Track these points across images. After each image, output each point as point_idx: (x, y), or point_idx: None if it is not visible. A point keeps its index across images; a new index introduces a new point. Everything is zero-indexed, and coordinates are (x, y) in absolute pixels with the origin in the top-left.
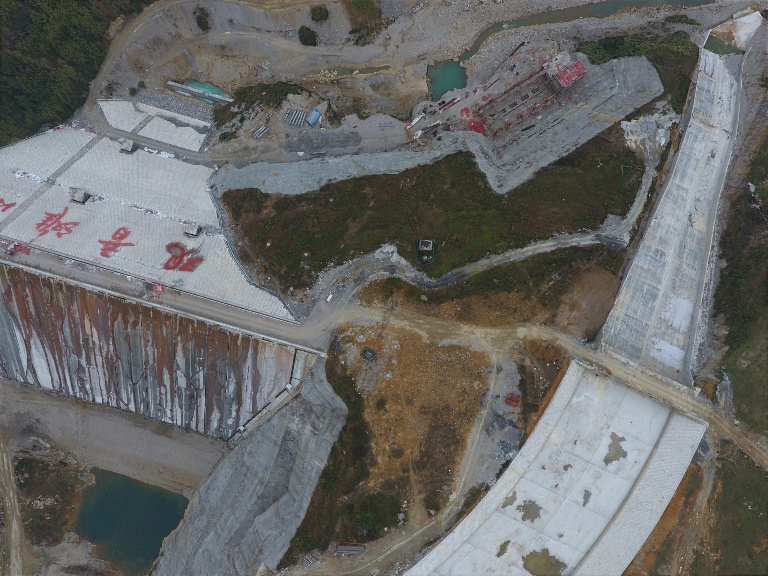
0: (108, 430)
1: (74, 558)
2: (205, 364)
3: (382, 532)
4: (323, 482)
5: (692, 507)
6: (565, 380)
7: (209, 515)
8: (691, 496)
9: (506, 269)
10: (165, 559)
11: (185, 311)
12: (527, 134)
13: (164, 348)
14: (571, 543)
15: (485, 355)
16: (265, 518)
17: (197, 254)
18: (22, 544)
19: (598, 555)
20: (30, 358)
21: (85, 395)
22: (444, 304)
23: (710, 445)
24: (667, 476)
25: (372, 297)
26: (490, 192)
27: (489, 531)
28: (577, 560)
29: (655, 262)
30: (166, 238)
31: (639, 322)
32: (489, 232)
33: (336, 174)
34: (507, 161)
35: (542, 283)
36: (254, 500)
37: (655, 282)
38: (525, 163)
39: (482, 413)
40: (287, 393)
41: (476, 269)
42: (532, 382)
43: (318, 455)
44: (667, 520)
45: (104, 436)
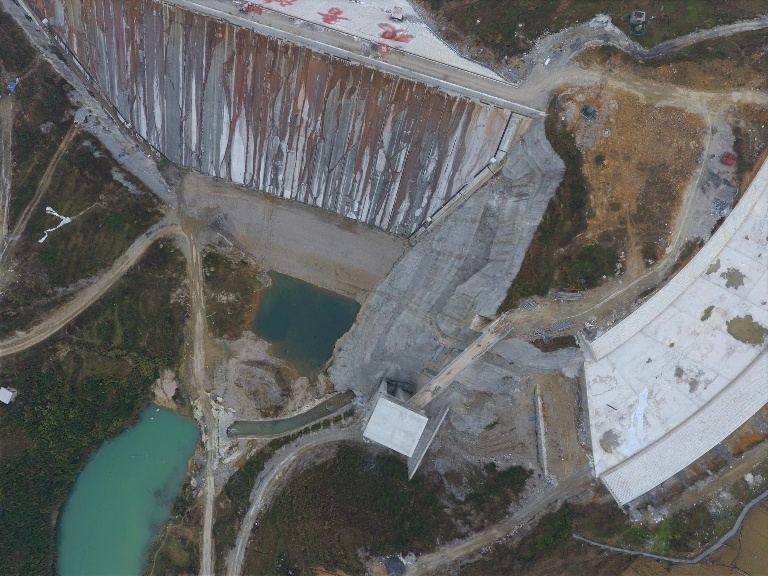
0: (293, 226)
1: (252, 354)
2: (411, 139)
3: (600, 281)
4: (540, 235)
5: None
6: None
7: (399, 298)
8: None
9: (716, 41)
10: (346, 351)
11: (409, 70)
12: None
13: (373, 121)
14: None
15: (700, 117)
16: (470, 283)
17: (407, 33)
18: (205, 336)
19: None
20: (230, 145)
21: (275, 189)
22: (661, 67)
23: None
24: None
25: (591, 59)
26: None
27: (694, 296)
28: None
29: None
30: (375, 19)
31: None
32: (695, 12)
33: None
34: None
35: (754, 53)
36: (454, 272)
37: None
38: None
39: (697, 171)
40: (488, 171)
41: (686, 42)
42: (748, 142)
43: (529, 216)
44: None
45: (288, 233)
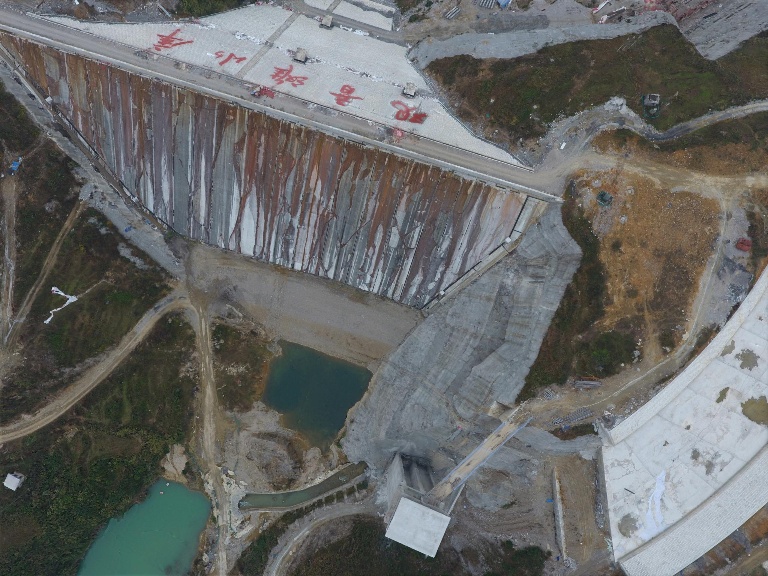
0: (304, 297)
1: (263, 425)
2: (425, 218)
3: (618, 368)
4: (558, 321)
5: None
6: None
7: (414, 374)
8: None
9: (730, 124)
10: (359, 423)
11: (424, 155)
12: (711, 20)
13: (387, 201)
14: None
15: (715, 202)
16: (486, 365)
17: (420, 111)
18: (215, 409)
19: None
20: (240, 219)
21: (285, 261)
22: (676, 152)
23: None
24: None
25: (607, 144)
26: (701, 58)
27: (709, 378)
28: None
29: None
30: (388, 96)
31: None
32: (708, 92)
33: (548, 41)
34: (699, 41)
35: (767, 136)
36: (470, 352)
37: None
38: (719, 41)
39: (713, 257)
40: (502, 249)
41: (700, 124)
42: (762, 227)
43: (546, 300)
44: None
45: (299, 304)
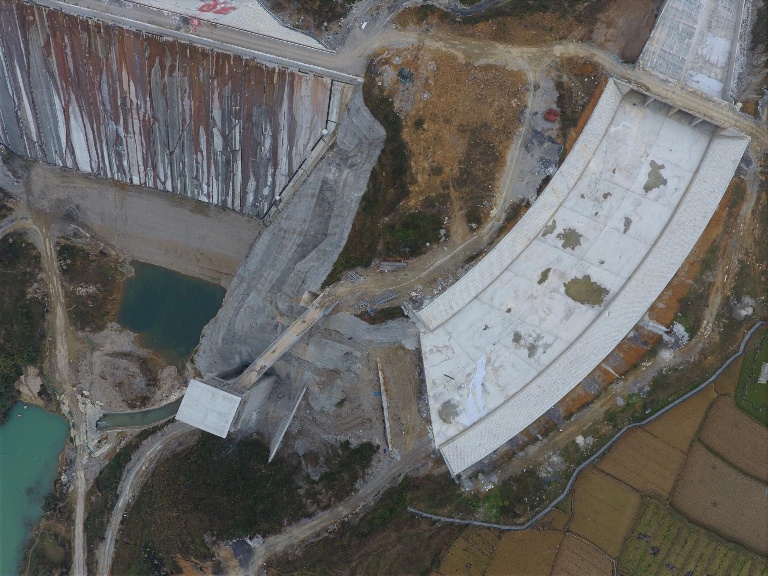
0: (146, 213)
1: (117, 345)
2: (241, 115)
3: (424, 248)
4: (364, 205)
5: (736, 218)
6: (603, 99)
7: (249, 279)
8: (735, 207)
9: None
10: (206, 337)
11: (222, 43)
12: None
13: (201, 99)
14: (612, 269)
15: (522, 73)
16: (306, 260)
17: (230, 5)
18: (67, 330)
19: (640, 276)
20: (69, 132)
21: (123, 176)
22: (479, 24)
23: (753, 159)
24: (709, 193)
25: (407, 19)
26: None
27: (530, 259)
28: (619, 286)
29: (690, 4)
30: None
31: (676, 57)
32: None
33: None
34: None
35: (577, 4)
36: (294, 249)
37: (691, 22)
38: None
39: (521, 130)
40: (323, 143)
41: None
42: (570, 96)
43: (357, 187)
44: (711, 231)
45: (142, 220)
